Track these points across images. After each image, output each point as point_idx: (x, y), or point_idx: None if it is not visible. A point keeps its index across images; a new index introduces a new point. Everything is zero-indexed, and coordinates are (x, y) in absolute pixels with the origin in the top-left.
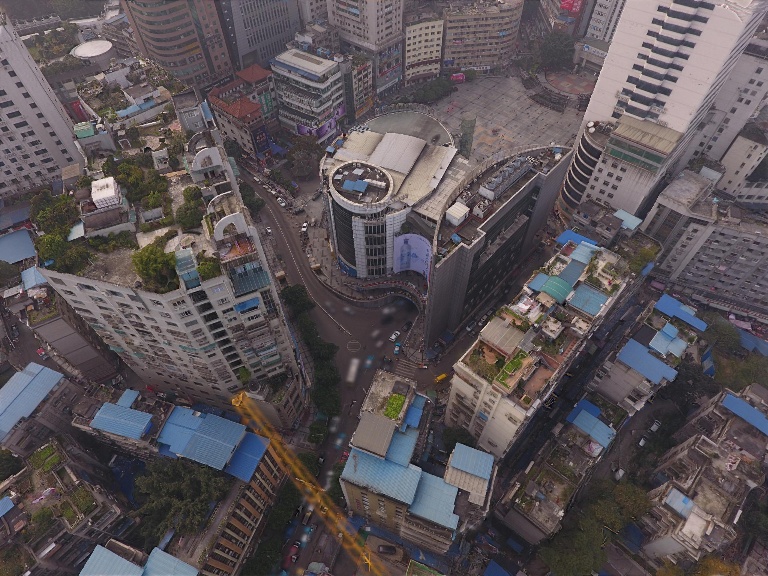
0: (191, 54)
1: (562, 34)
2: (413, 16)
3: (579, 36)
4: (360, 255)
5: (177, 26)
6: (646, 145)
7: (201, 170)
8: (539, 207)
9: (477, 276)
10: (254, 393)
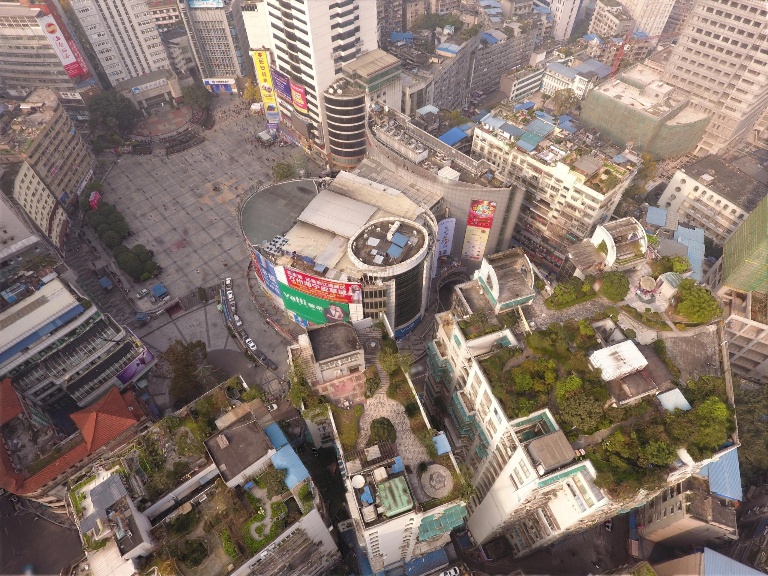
0: None
1: (104, 96)
2: None
3: None
4: (425, 293)
5: None
6: (388, 65)
7: None
8: None
9: None
10: None
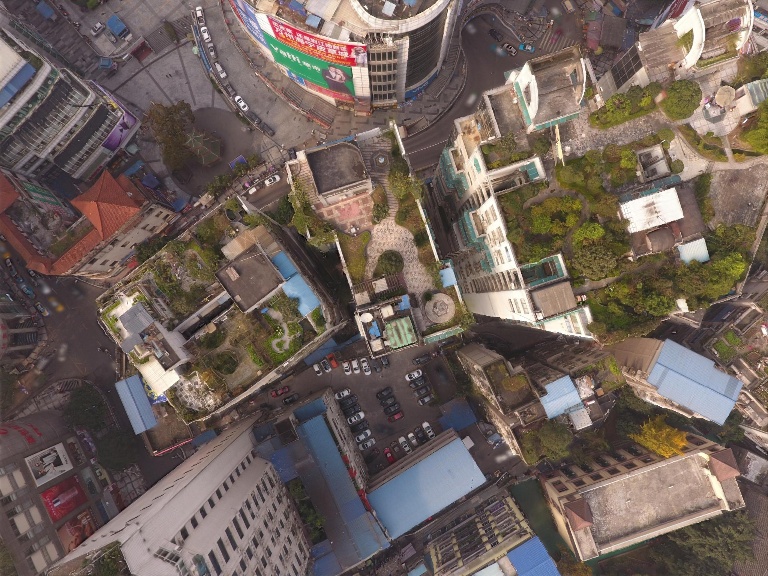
0: None
1: None
2: None
3: None
4: None
5: None
6: None
7: None
8: None
9: None
10: None
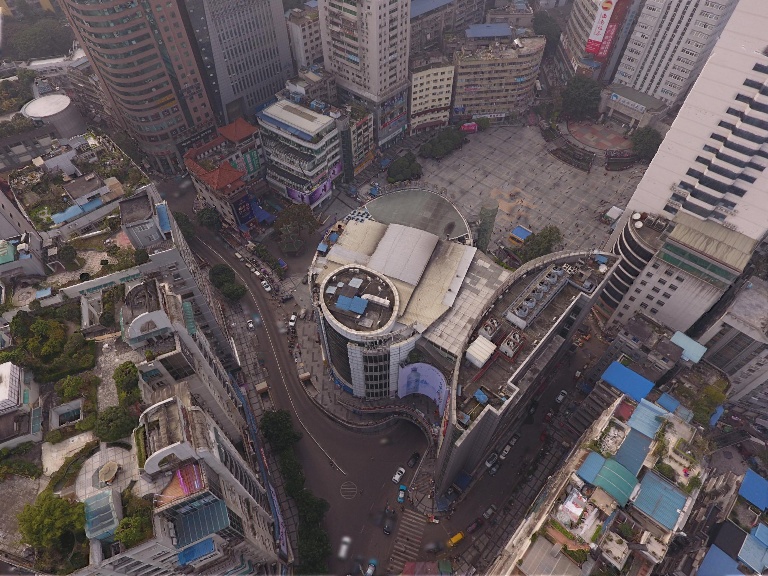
0: (165, 107)
1: (587, 80)
2: (420, 61)
3: (604, 81)
4: (357, 378)
5: (148, 78)
6: (713, 257)
7: (141, 336)
8: (577, 324)
9: (503, 421)
10: None
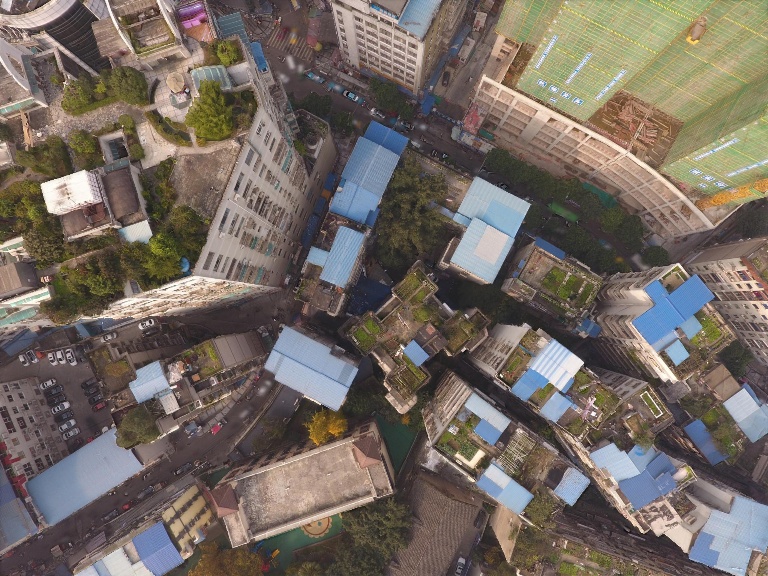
0: None
1: None
2: None
3: None
4: None
5: None
6: None
7: (30, 82)
8: None
9: None
10: (317, 144)
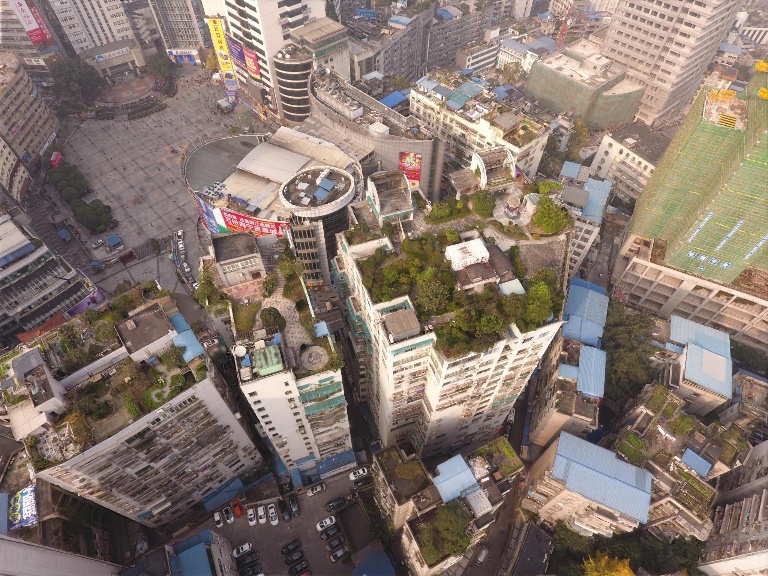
0: None
1: (67, 62)
2: None
3: None
4: None
5: None
6: (334, 32)
7: None
8: None
9: None
10: None
